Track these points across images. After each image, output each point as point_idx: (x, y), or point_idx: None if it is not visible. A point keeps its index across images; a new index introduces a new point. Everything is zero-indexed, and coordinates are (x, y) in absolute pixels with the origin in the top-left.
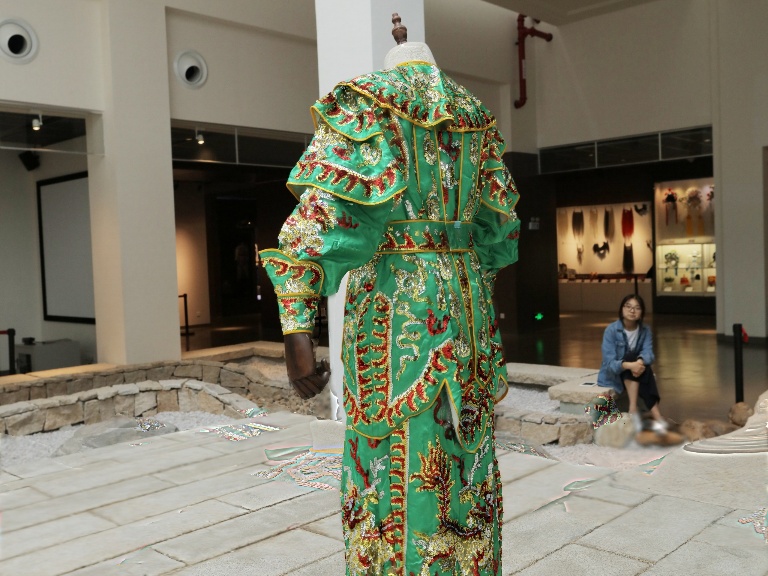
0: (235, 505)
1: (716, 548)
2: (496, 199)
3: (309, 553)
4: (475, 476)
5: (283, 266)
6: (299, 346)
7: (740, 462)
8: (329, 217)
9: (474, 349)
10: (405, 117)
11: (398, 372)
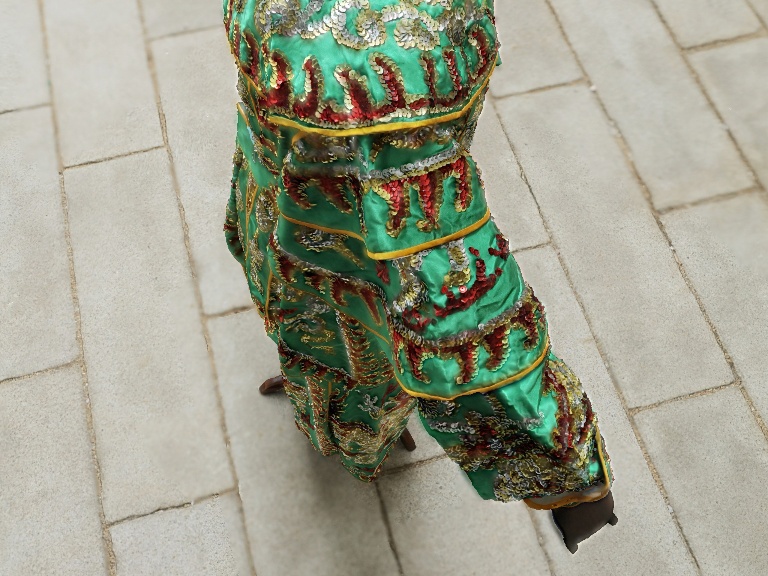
0: None
1: None
2: None
3: None
4: None
5: None
6: None
7: None
8: None
9: None
10: None
11: None
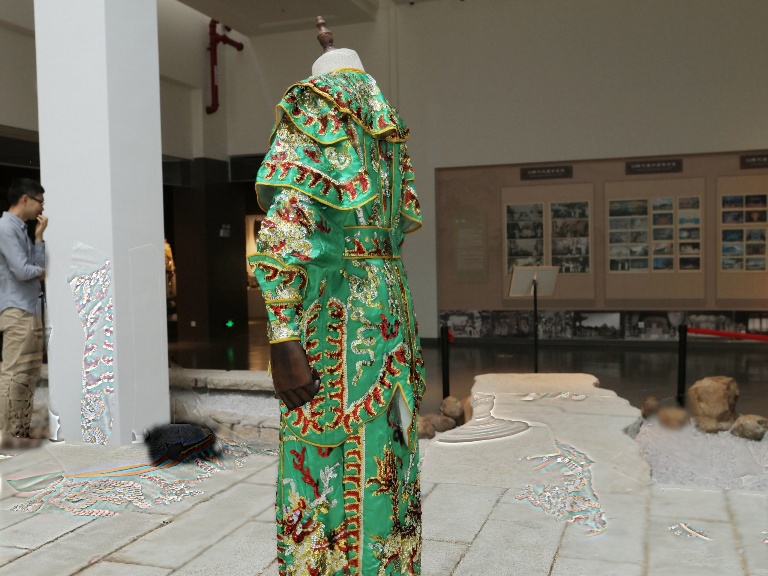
0: (7, 546)
1: (512, 523)
2: (411, 208)
3: None
4: (410, 475)
5: (273, 271)
6: (294, 354)
7: (488, 448)
8: (309, 220)
9: (412, 352)
10: (360, 123)
11: (354, 378)
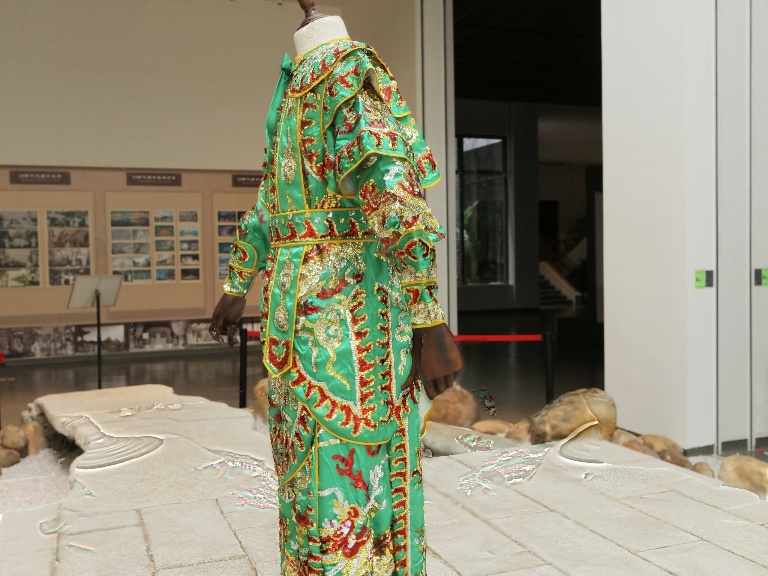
0: None
1: (262, 528)
2: None
3: None
4: None
5: (426, 247)
6: (448, 337)
7: (146, 466)
8: None
9: None
10: None
11: (400, 367)
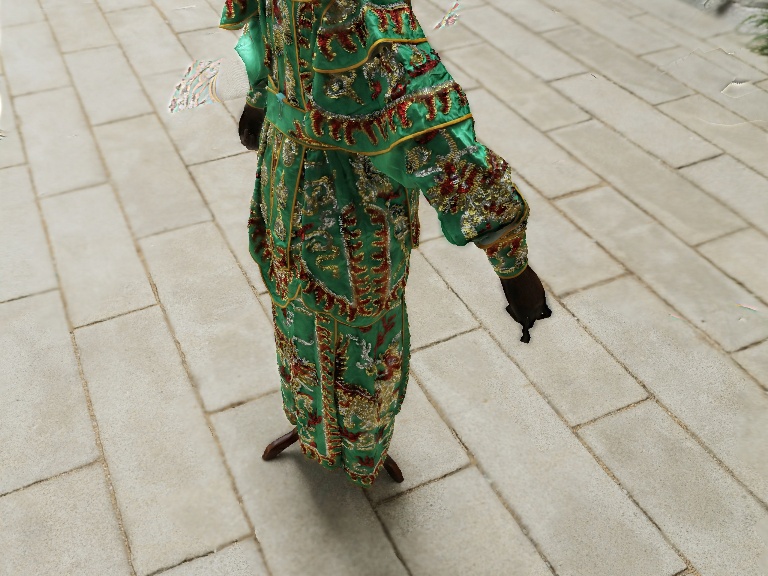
0: None
1: None
2: None
3: (746, 459)
4: None
5: None
6: None
7: None
8: None
9: None
10: None
11: None
